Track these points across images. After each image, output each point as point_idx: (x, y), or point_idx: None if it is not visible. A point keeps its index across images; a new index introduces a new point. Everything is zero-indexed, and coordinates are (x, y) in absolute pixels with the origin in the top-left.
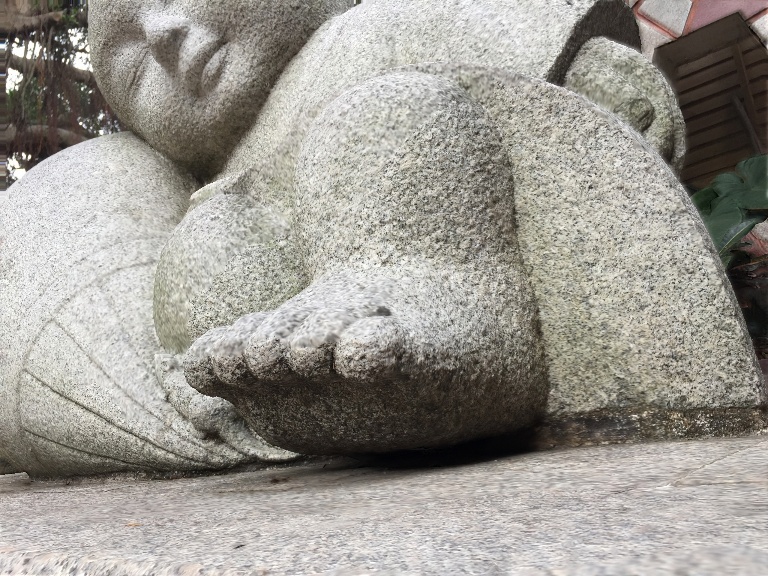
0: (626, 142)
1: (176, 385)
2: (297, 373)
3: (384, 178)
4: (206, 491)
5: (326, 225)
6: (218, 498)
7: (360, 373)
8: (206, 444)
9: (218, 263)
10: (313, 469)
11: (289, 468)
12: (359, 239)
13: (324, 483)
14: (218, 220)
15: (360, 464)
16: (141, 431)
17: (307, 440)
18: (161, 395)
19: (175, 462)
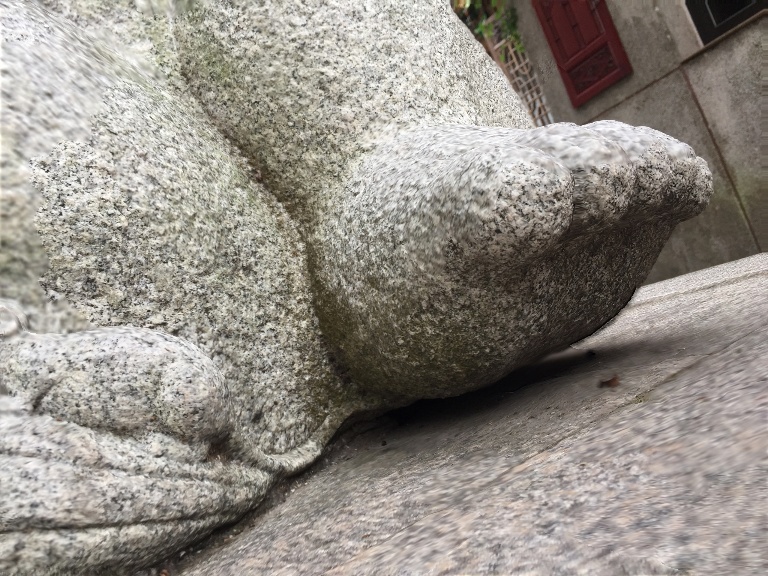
0: (504, 79)
1: (80, 357)
2: (675, 195)
3: (443, 23)
4: (584, 424)
5: (389, 60)
6: (757, 357)
7: (707, 197)
8: (214, 469)
9: (84, 93)
10: (423, 434)
11: (336, 469)
12: (443, 89)
13: (653, 361)
14: (11, 8)
15: (495, 393)
16: (1, 507)
17: (545, 339)
18: (6, 401)
19: (148, 544)
